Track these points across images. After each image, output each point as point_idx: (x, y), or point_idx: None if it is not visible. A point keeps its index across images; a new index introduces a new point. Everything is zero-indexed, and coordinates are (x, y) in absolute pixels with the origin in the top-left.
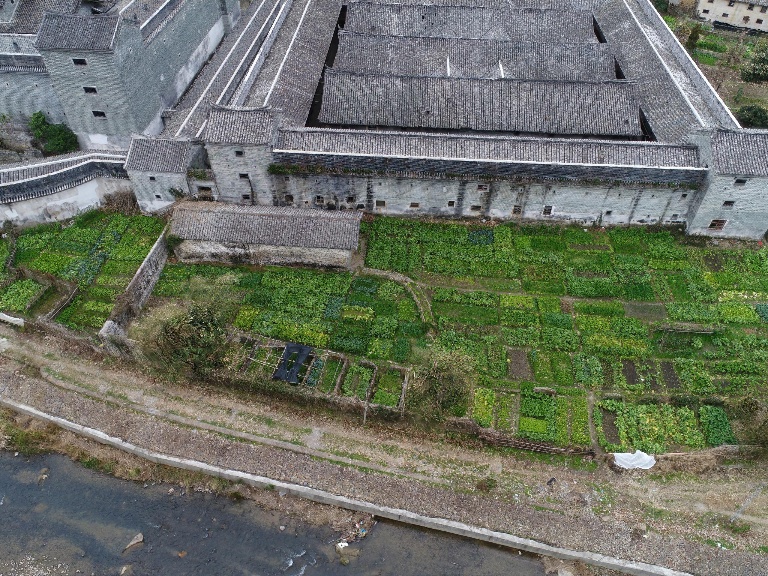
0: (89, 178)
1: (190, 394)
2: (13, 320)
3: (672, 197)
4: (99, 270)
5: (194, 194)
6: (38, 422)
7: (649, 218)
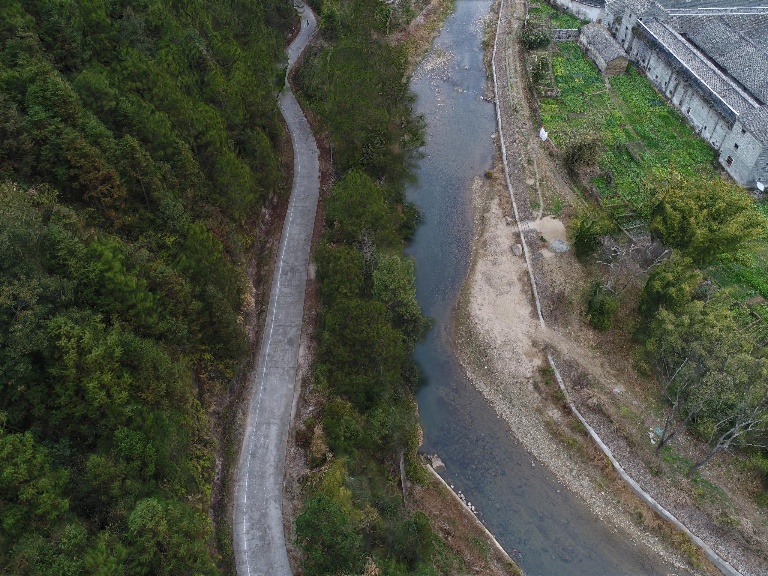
0: (599, 7)
1: None
2: None
3: (727, 132)
4: None
5: None
6: None
7: (716, 143)
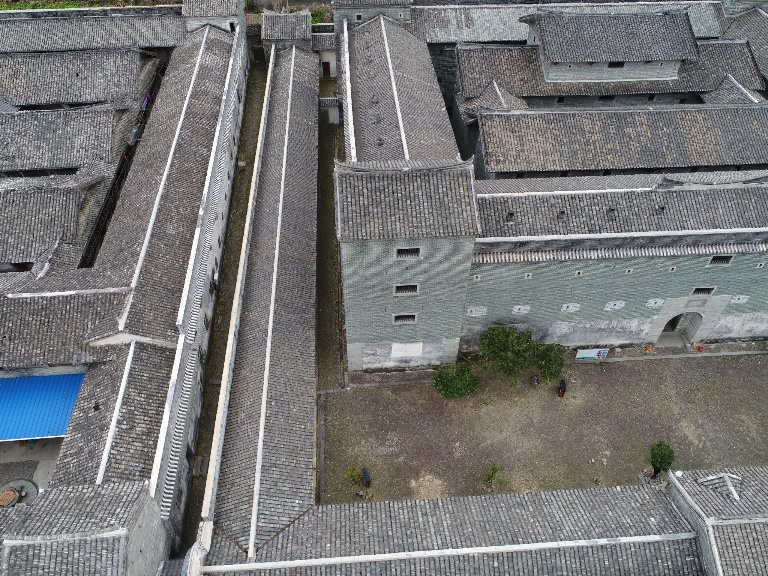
0: None
1: None
2: None
3: None
4: None
5: None
6: None
7: None
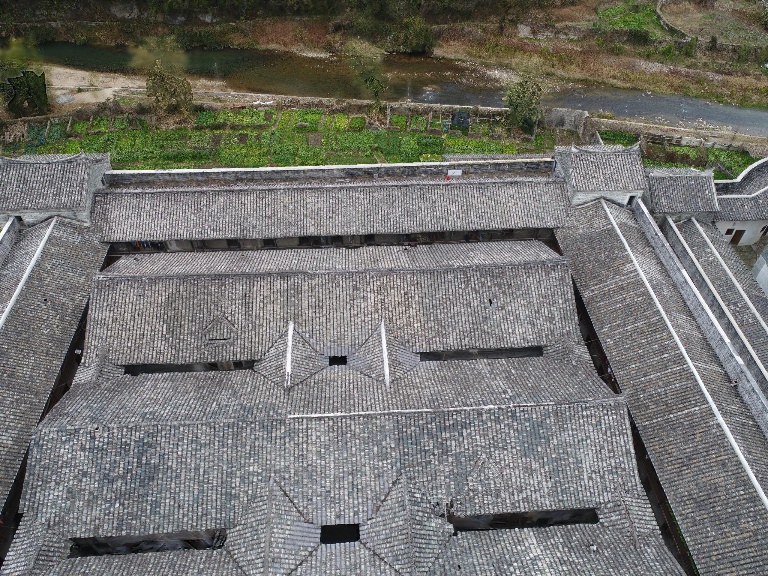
0: None
1: None
2: None
3: None
4: None
5: None
6: None
7: None
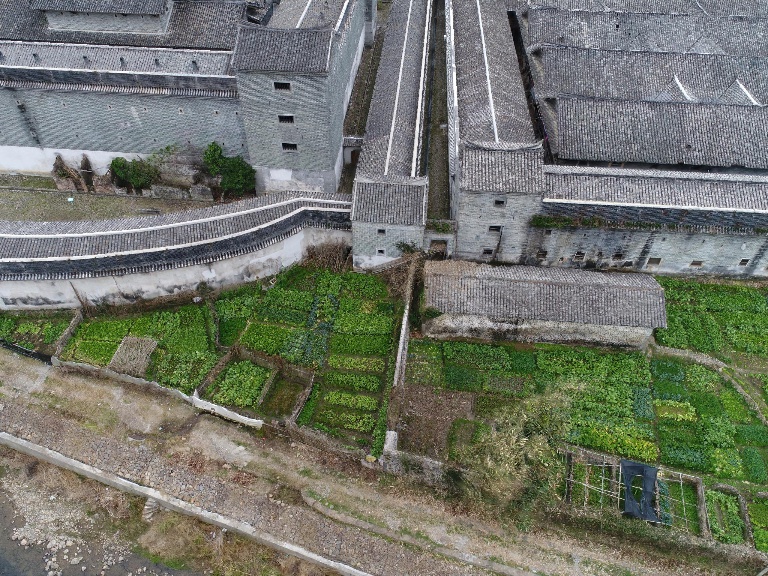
0: (298, 229)
1: (508, 531)
2: (247, 421)
3: None
4: (326, 347)
5: (435, 251)
6: (309, 566)
7: None
